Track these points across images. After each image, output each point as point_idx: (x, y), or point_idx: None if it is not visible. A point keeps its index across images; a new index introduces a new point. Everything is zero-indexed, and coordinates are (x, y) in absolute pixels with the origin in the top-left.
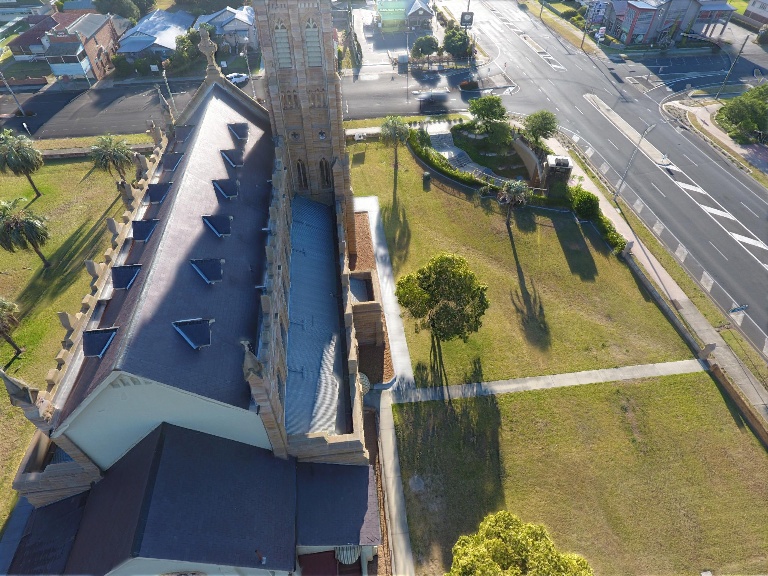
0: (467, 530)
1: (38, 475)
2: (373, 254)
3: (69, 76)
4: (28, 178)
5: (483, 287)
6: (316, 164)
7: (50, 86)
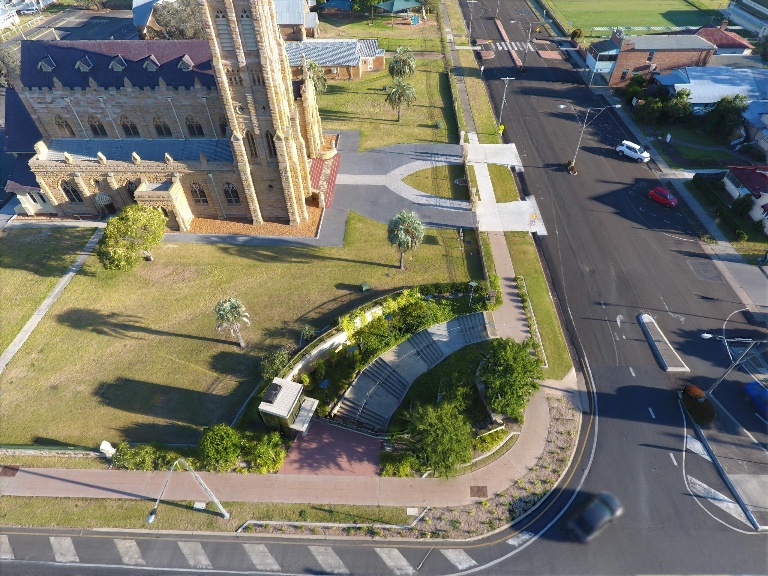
0: (5, 249)
1: None
2: (249, 234)
3: None
4: None
5: (109, 249)
6: None
7: None
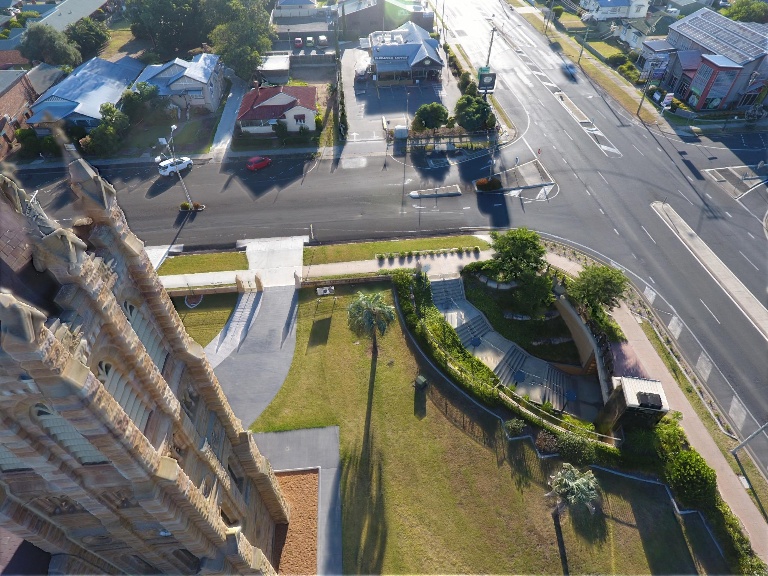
0: None
1: None
2: None
3: None
4: None
5: None
6: (166, 555)
7: None
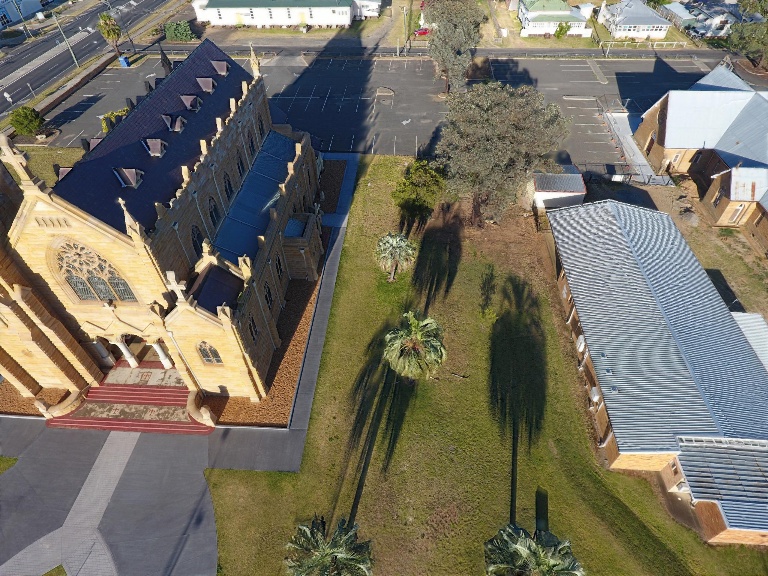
0: None
1: (297, 132)
2: None
3: None
4: None
5: None
6: None
7: None
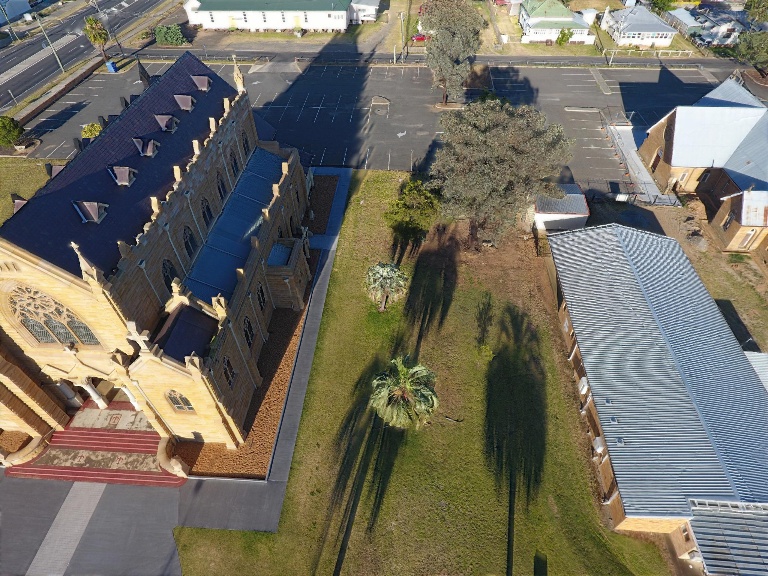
0: None
1: (285, 149)
2: None
3: None
4: None
5: None
6: None
7: None
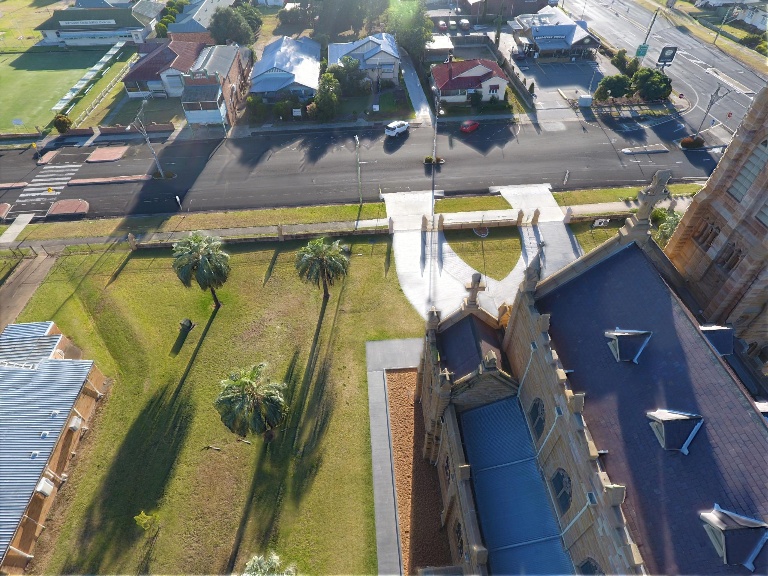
0: None
1: None
2: None
3: (204, 124)
4: (210, 288)
5: None
6: None
7: (178, 133)
